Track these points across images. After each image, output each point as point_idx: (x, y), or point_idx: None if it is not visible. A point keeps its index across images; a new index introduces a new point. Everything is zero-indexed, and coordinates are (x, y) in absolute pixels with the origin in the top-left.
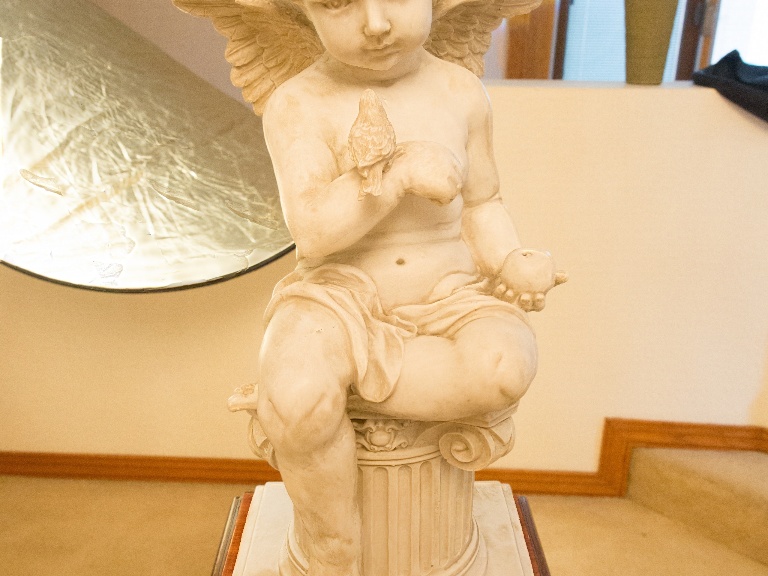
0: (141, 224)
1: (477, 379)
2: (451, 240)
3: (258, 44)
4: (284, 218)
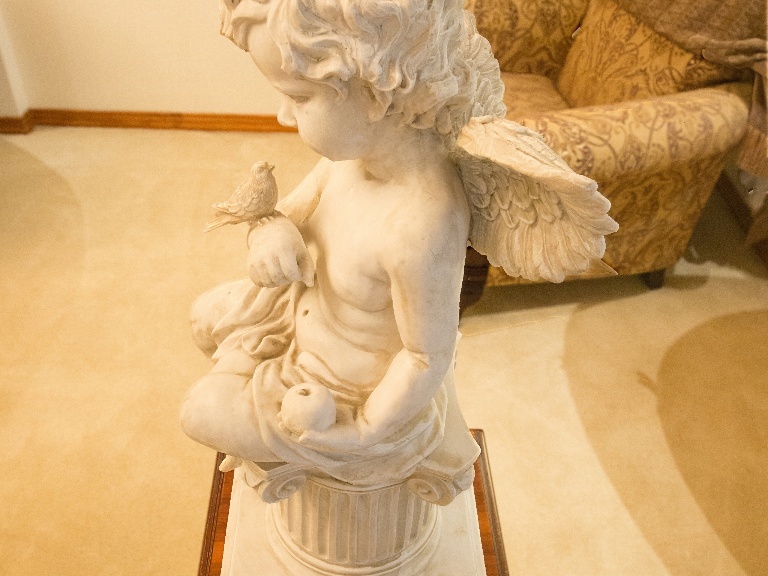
0: None
1: None
2: (345, 339)
3: None
4: None
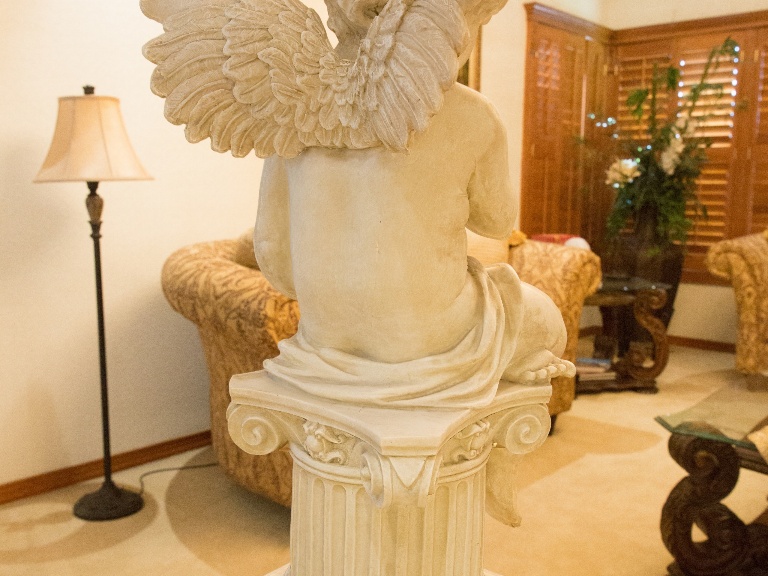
0: None
1: None
2: None
3: None
4: None
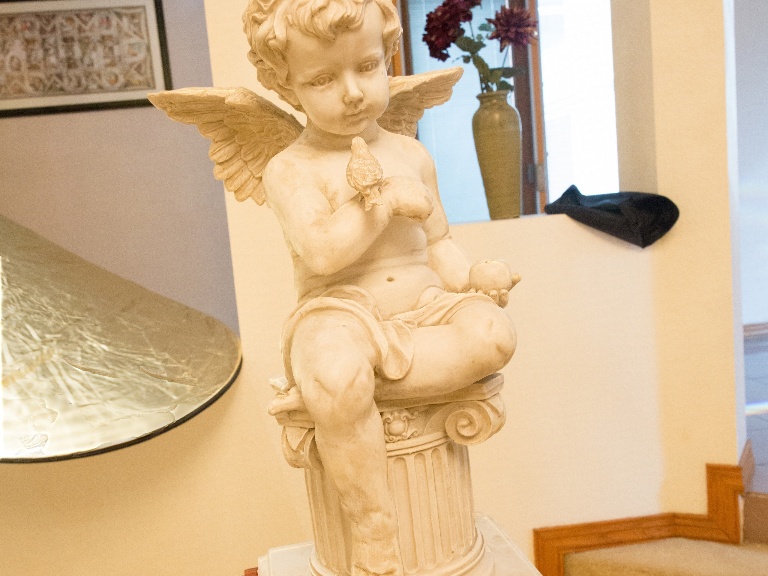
0: (60, 395)
1: (477, 341)
2: (423, 264)
3: (237, 143)
4: (297, 248)
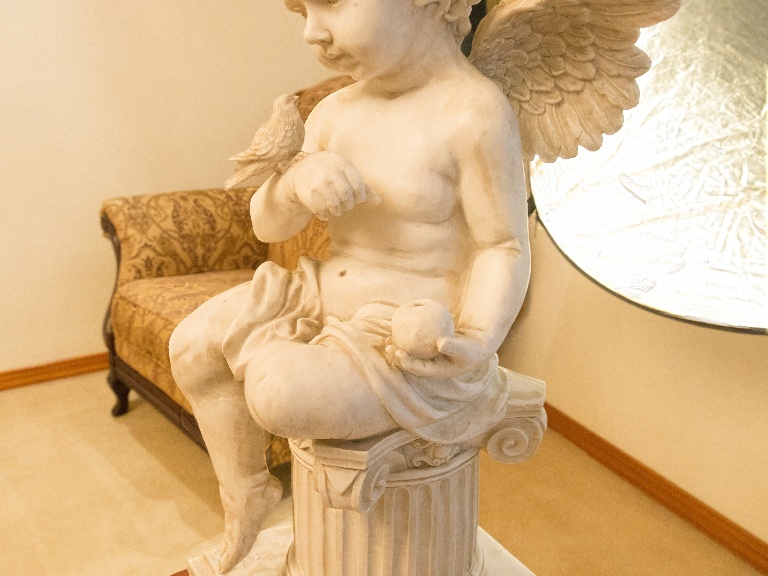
0: (707, 250)
1: None
2: (410, 272)
3: None
4: None
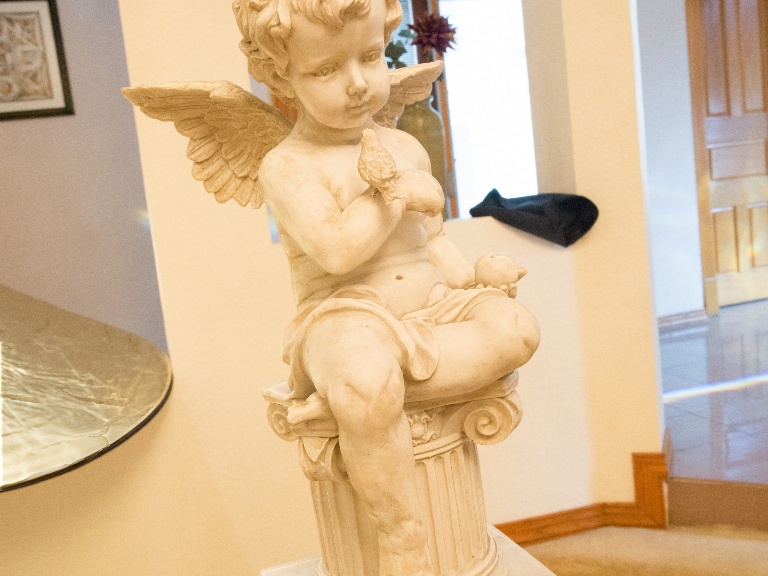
0: None
1: (505, 336)
2: None
3: (217, 140)
4: (307, 247)
